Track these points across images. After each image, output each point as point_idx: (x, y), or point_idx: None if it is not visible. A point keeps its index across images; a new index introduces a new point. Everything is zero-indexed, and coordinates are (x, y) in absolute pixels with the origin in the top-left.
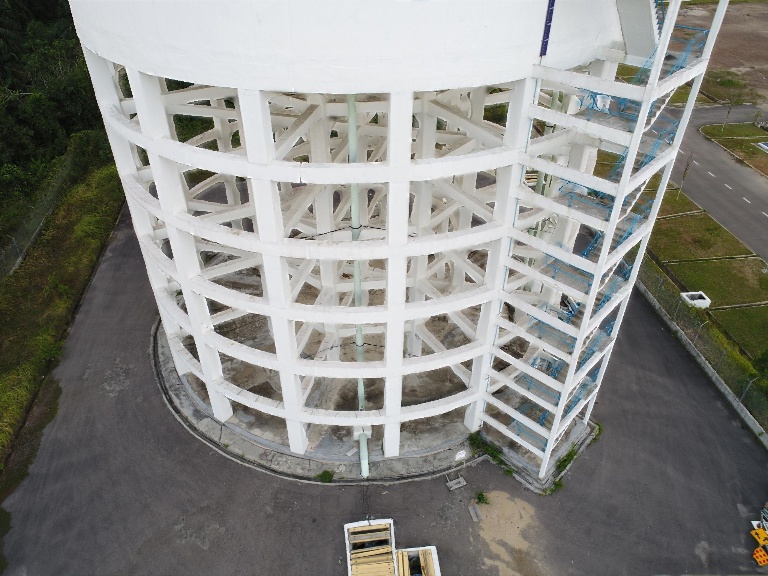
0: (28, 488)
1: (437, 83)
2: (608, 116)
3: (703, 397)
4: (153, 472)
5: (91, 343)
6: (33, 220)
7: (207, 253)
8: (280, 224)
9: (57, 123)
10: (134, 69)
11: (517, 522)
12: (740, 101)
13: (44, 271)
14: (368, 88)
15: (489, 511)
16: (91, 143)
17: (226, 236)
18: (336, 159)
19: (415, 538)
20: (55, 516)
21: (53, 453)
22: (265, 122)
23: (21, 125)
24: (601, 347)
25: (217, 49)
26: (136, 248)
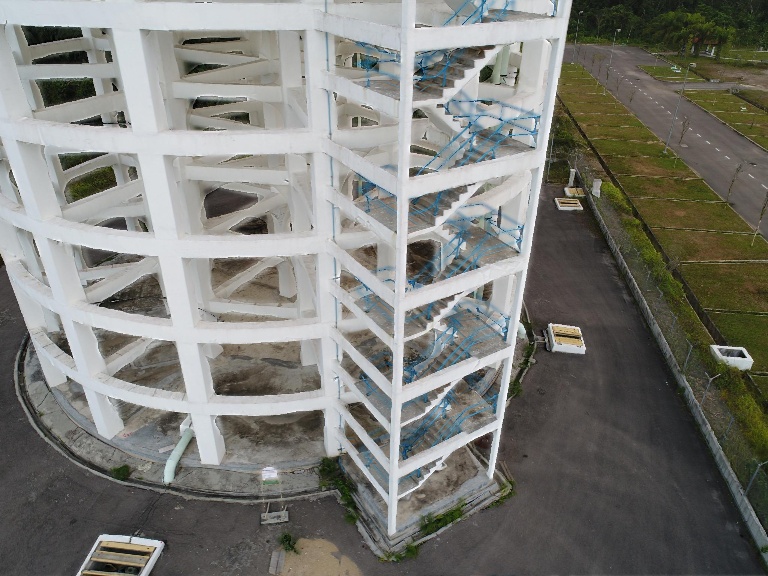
0: None
1: None
2: None
3: (692, 480)
4: None
5: None
6: None
7: None
8: (17, 96)
9: None
10: None
11: None
12: None
13: None
14: None
15: (296, 564)
16: None
17: None
18: (198, 76)
19: (179, 575)
20: None
21: None
22: None
23: None
24: (483, 352)
25: None
26: None
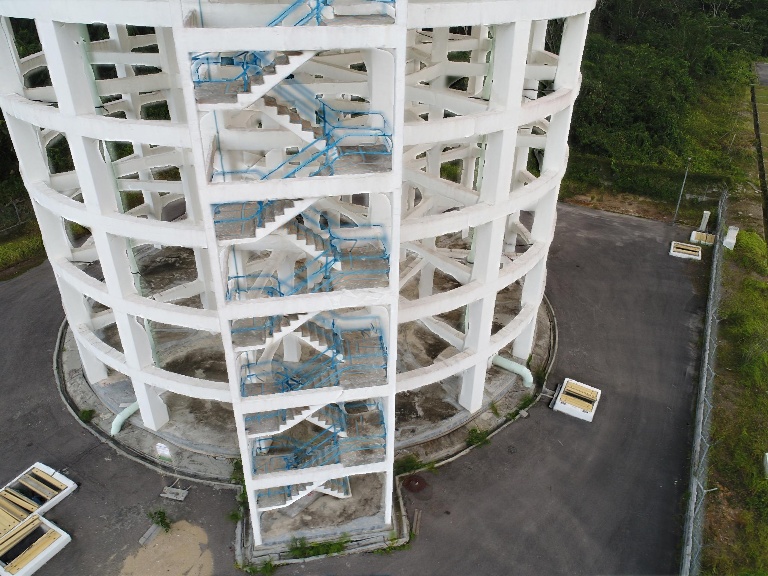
0: None
1: None
2: None
3: None
4: (1, 343)
5: None
6: None
7: None
8: (9, 75)
9: None
10: None
11: (174, 575)
12: None
13: None
14: None
15: (163, 542)
16: None
17: None
18: None
19: (72, 517)
20: None
21: None
22: None
23: None
24: (354, 384)
25: None
26: None
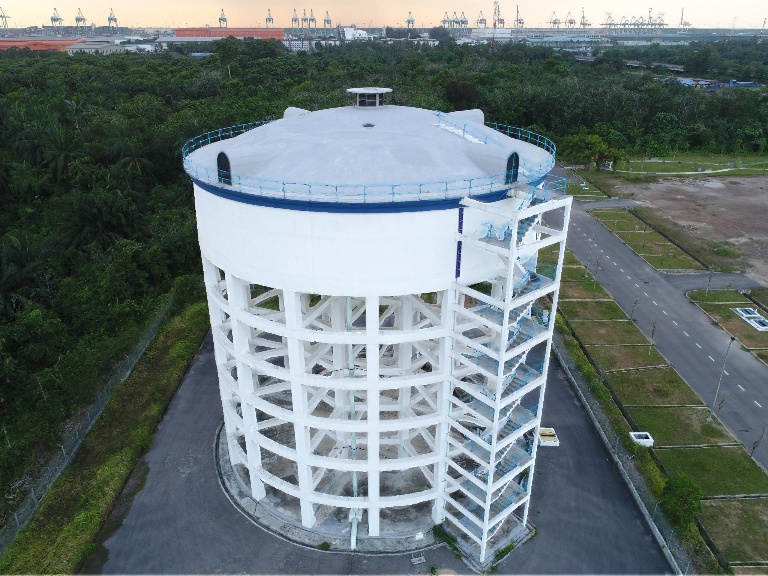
0: (121, 534)
1: (392, 292)
2: (495, 314)
3: (626, 516)
4: (206, 532)
5: (173, 437)
6: (141, 343)
7: (263, 376)
8: (303, 365)
9: (166, 268)
10: (229, 273)
11: None
12: (730, 270)
13: (145, 382)
14: (353, 294)
15: None
16: (189, 285)
17: (270, 370)
18: None
19: None
20: (137, 555)
21: (140, 512)
22: (297, 308)
23: (141, 270)
24: (522, 463)
25: (274, 270)
26: (212, 369)
